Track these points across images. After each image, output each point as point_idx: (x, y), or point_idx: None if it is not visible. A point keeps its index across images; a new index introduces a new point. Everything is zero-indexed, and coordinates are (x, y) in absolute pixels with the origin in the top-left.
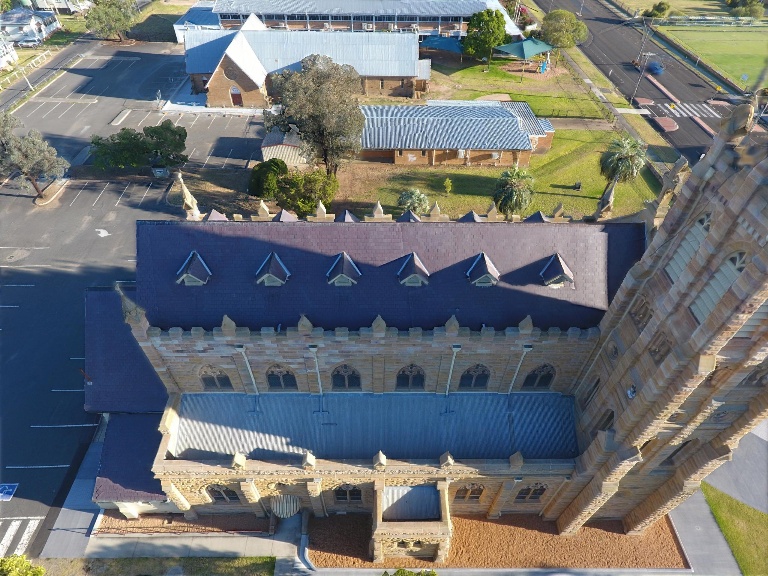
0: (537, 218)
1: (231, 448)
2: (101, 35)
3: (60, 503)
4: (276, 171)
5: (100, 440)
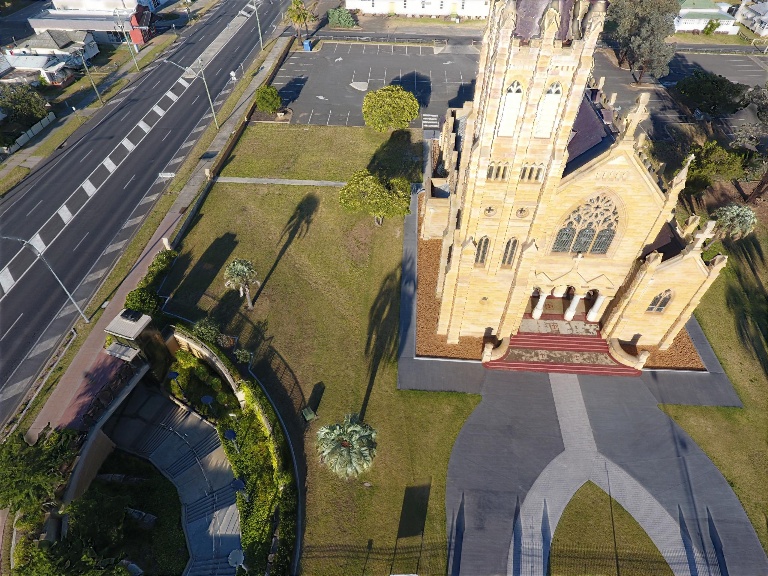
0: None
1: (461, 130)
2: None
3: None
4: (741, 157)
5: None
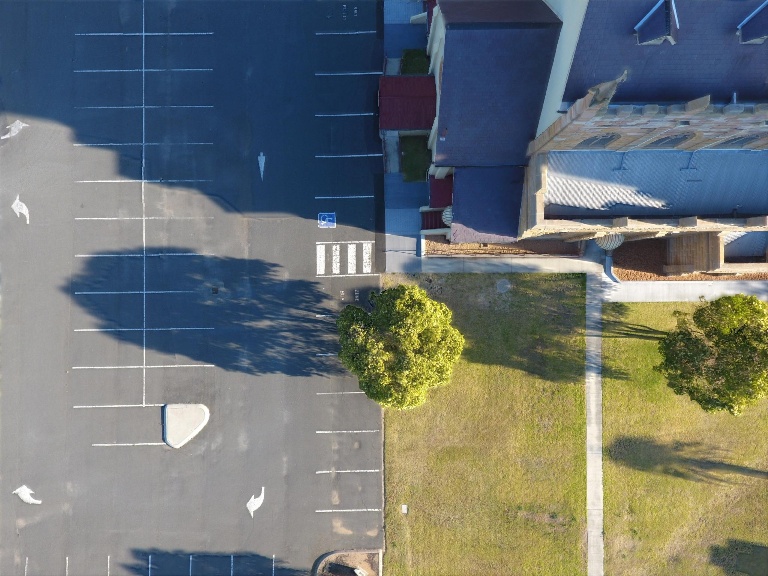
0: None
1: (592, 203)
2: None
3: (382, 230)
4: None
5: (392, 171)
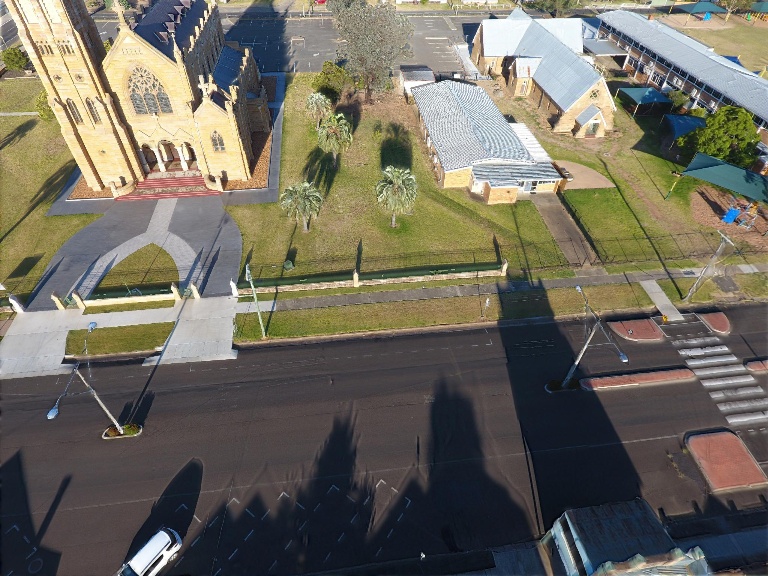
0: None
1: None
2: (537, 6)
3: None
4: None
5: None
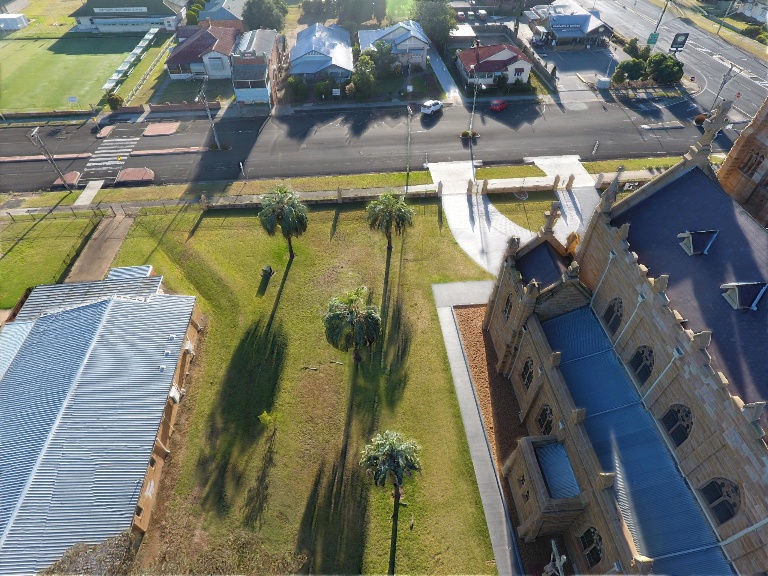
0: (701, 237)
1: None
2: None
3: None
4: None
5: None
